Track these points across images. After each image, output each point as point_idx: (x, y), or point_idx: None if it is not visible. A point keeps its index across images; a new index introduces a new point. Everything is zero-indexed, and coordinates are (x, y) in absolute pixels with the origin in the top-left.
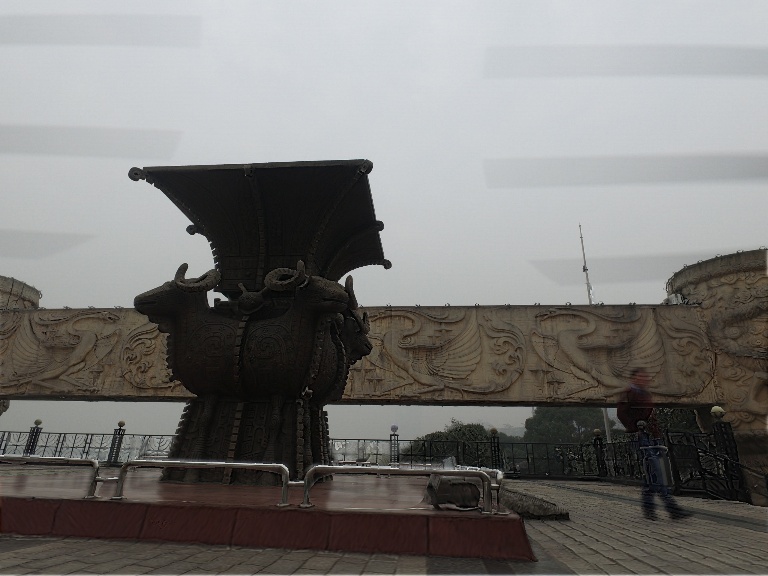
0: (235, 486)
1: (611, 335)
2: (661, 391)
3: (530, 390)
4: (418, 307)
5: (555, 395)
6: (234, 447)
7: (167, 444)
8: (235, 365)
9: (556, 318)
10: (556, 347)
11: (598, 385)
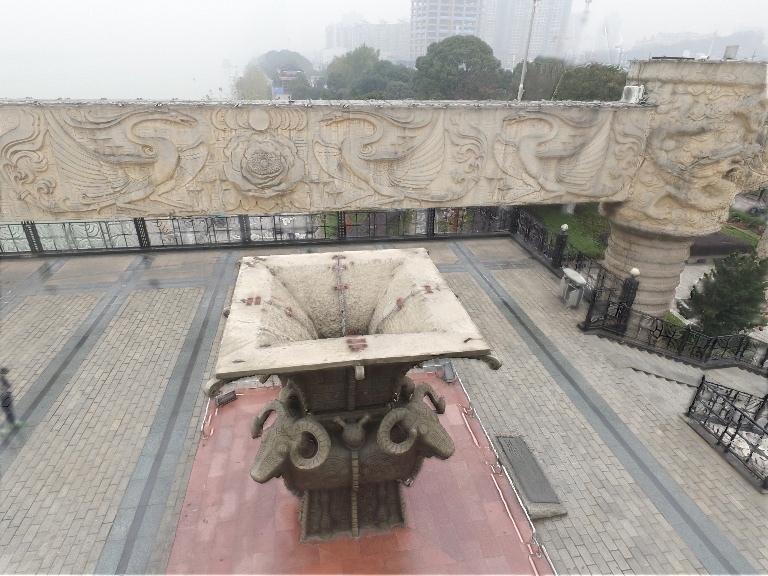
0: (369, 547)
1: (568, 141)
2: (589, 194)
3: (482, 196)
4: (380, 108)
5: (502, 200)
6: (356, 517)
7: (96, 231)
8: (355, 489)
9: (523, 122)
10: (515, 154)
11: (540, 189)
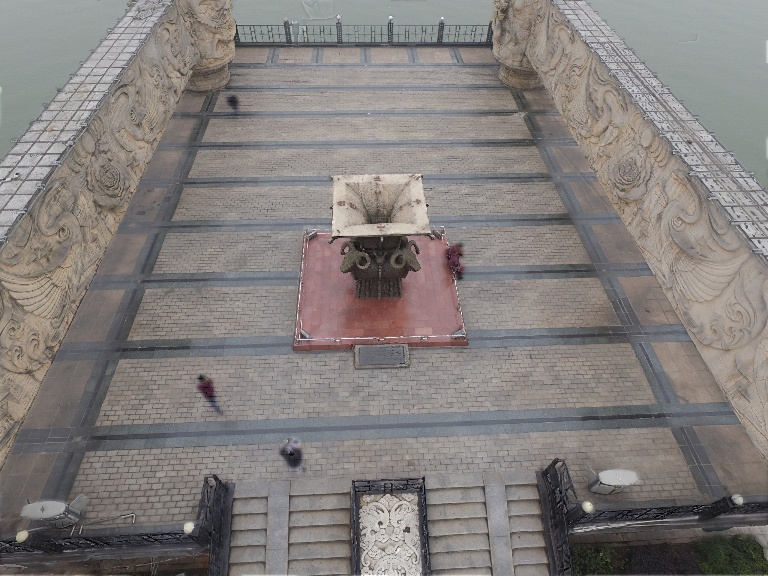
0: None
1: None
2: None
3: (719, 368)
4: (709, 199)
5: (730, 396)
6: None
7: None
8: None
9: None
10: None
11: None
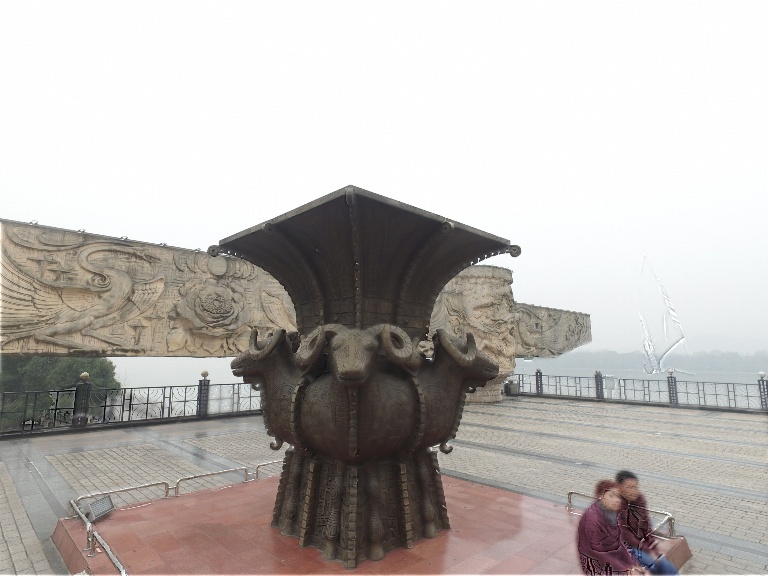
0: None
1: None
2: None
3: None
4: None
5: None
6: None
7: None
8: None
9: None
10: None
11: None
